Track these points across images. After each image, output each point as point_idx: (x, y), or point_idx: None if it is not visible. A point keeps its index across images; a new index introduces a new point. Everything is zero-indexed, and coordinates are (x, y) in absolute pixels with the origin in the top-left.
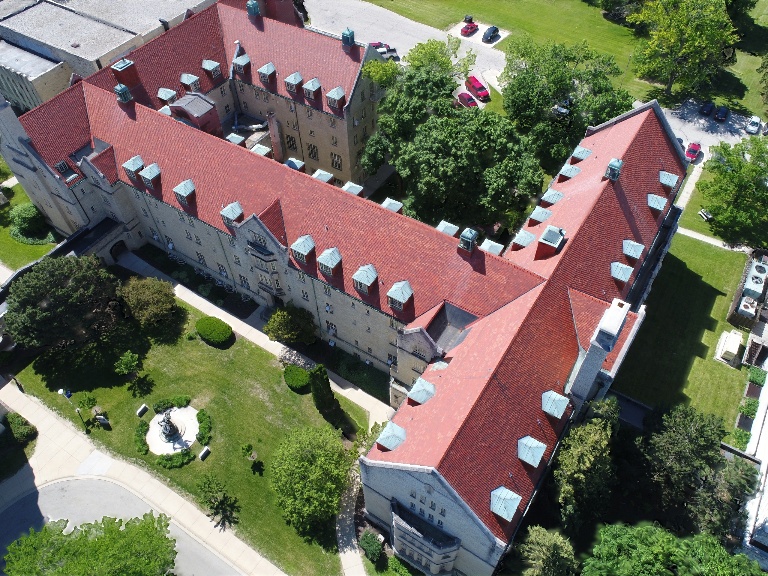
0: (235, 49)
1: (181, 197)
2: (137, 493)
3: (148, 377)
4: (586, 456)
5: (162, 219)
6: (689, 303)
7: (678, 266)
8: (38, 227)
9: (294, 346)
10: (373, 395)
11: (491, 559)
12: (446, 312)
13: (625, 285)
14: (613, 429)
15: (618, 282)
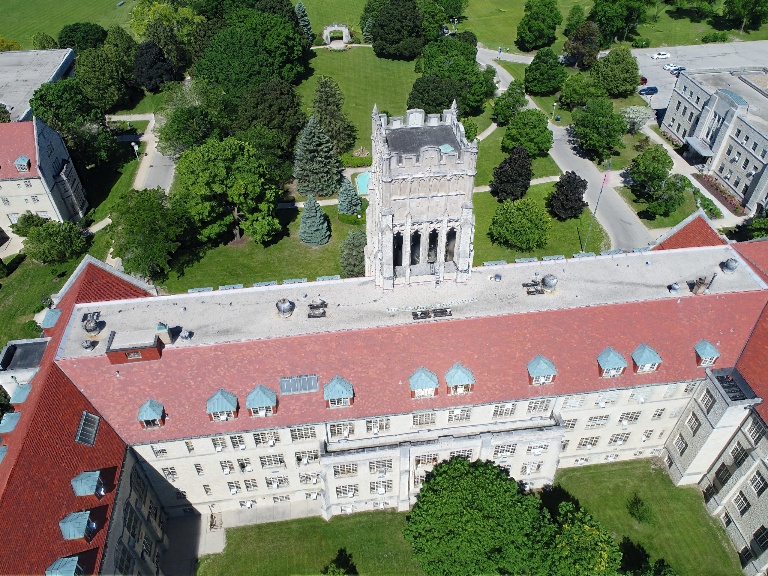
0: None
1: None
2: None
3: None
4: None
5: None
6: None
7: None
8: None
9: None
10: None
11: (66, 152)
12: None
13: None
14: None
15: None
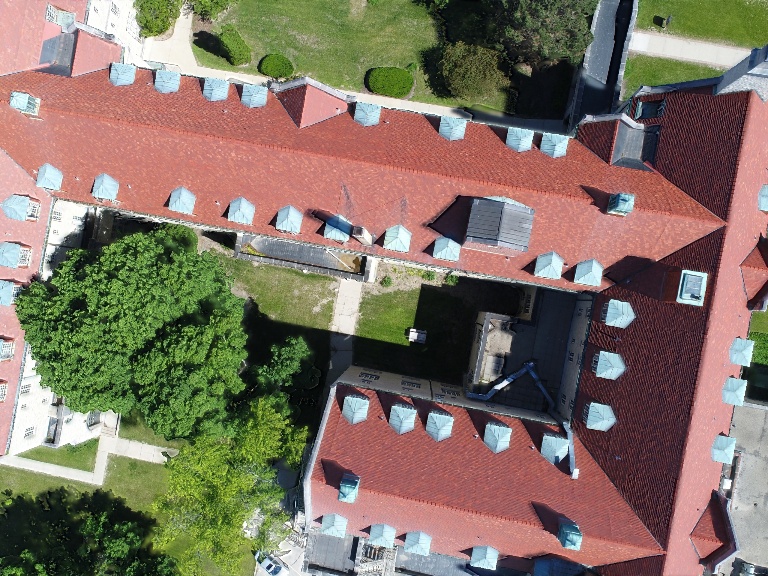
0: (581, 471)
1: None
2: None
3: (426, 6)
4: None
5: None
6: None
7: None
8: None
9: None
10: None
11: None
12: None
13: None
14: None
15: None
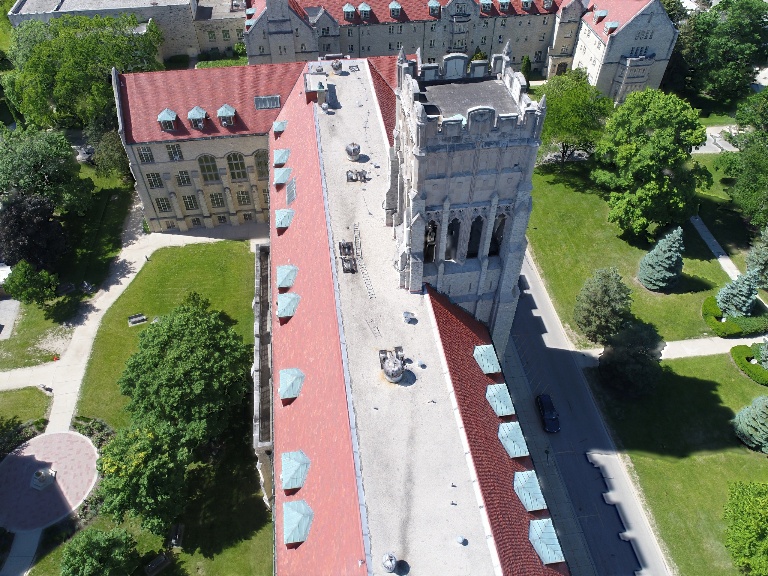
0: None
1: (396, 11)
2: None
3: None
4: (670, 3)
5: (369, 44)
6: None
7: None
8: None
9: None
10: (536, 80)
11: (669, 53)
12: None
13: None
14: None
15: None
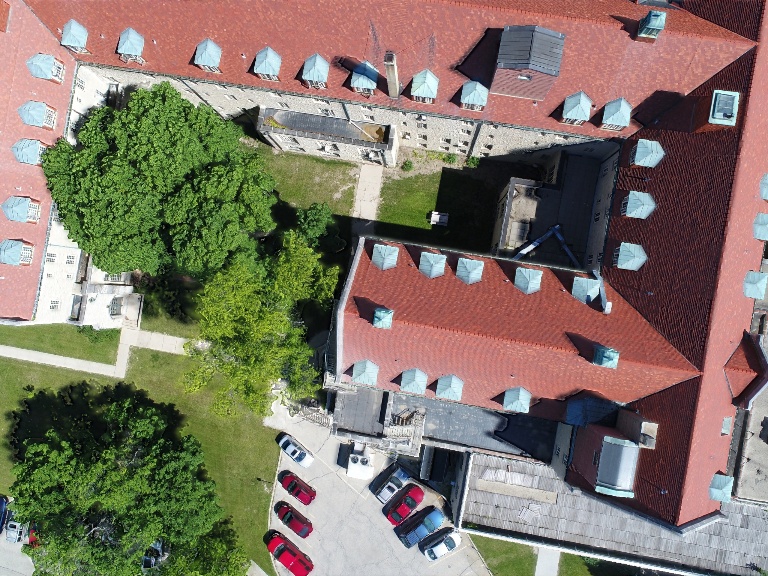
0: (612, 309)
1: None
2: None
3: None
4: None
5: None
6: None
7: None
8: None
9: None
10: None
11: None
12: None
13: None
14: None
15: None
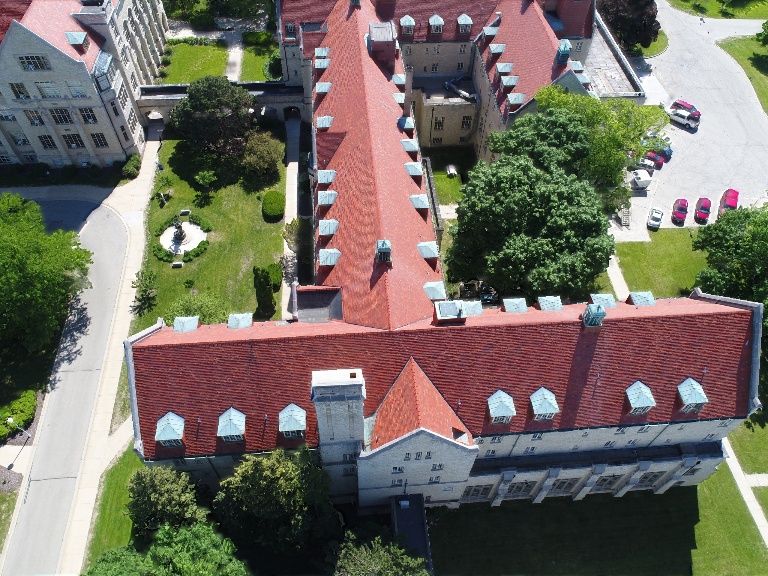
0: None
1: None
2: (128, 251)
3: (212, 198)
4: None
5: None
6: (641, 549)
7: (686, 514)
8: (278, 68)
9: (300, 257)
10: None
11: None
12: (335, 297)
13: (498, 422)
14: (308, 485)
15: (489, 411)
